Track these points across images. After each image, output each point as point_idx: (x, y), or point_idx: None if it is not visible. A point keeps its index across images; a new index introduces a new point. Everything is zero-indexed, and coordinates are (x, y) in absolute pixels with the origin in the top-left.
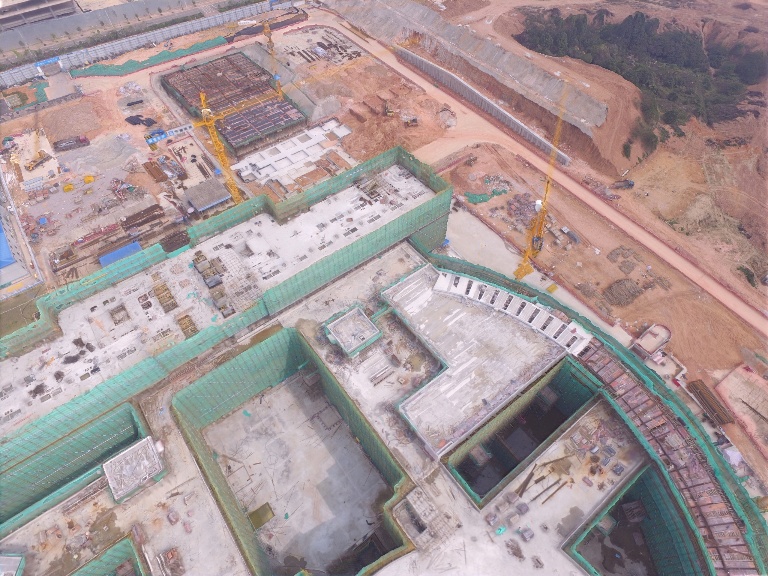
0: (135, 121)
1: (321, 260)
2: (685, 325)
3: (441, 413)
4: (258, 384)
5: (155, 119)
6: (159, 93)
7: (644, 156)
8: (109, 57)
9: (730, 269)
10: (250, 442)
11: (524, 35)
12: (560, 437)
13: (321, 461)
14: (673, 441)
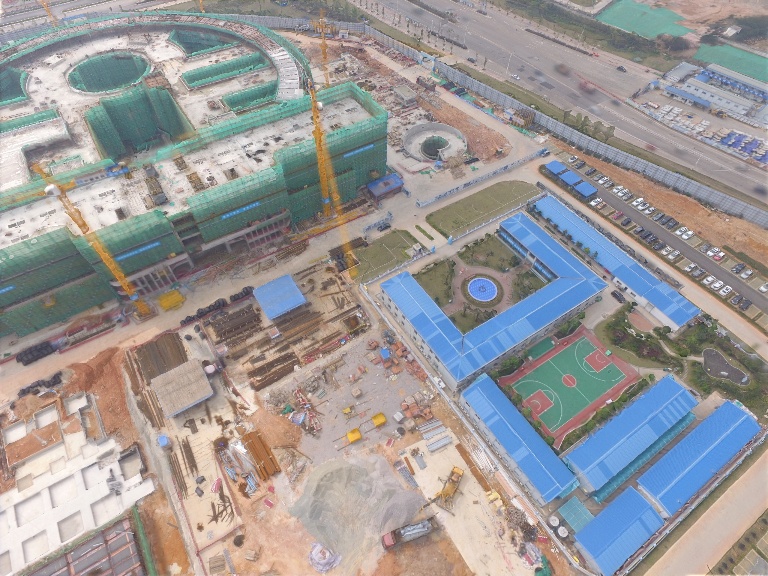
0: None
1: (53, 176)
2: None
3: (45, 132)
4: None
5: None
6: None
7: None
8: None
9: None
10: None
11: None
12: None
13: None
14: None
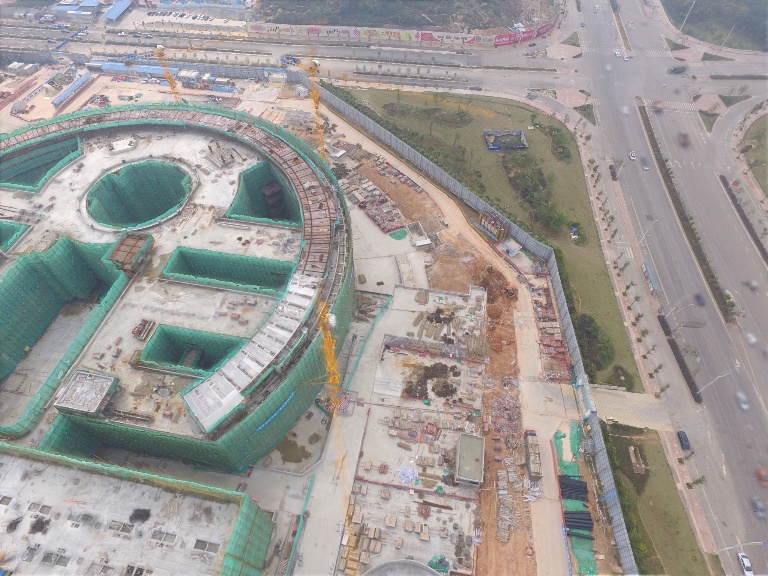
0: None
1: None
2: None
3: None
4: None
5: None
6: None
7: None
8: None
9: None
10: None
11: None
12: None
13: (58, 361)
14: None
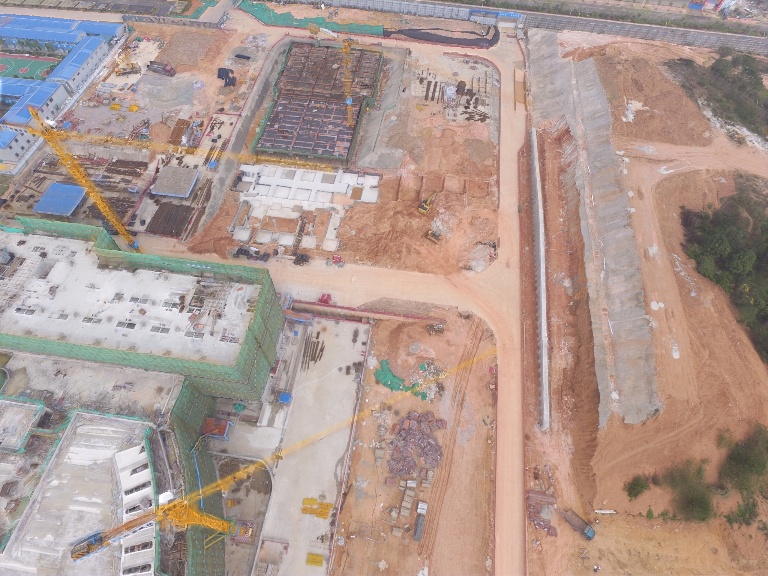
0: (221, 75)
1: (33, 338)
2: None
3: None
4: None
5: (238, 81)
6: (270, 58)
7: (664, 514)
8: (283, 1)
9: None
10: None
11: (694, 217)
12: None
13: None
14: None
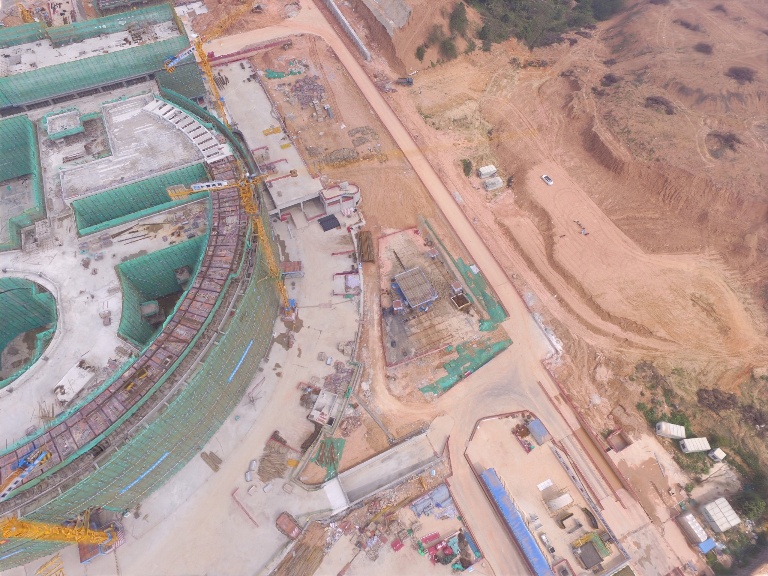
0: None
1: (49, 66)
2: (381, 191)
3: (87, 180)
4: (16, 165)
5: None
6: None
7: (438, 62)
8: None
9: (454, 159)
10: (0, 205)
11: None
12: (165, 211)
13: None
14: (229, 220)
